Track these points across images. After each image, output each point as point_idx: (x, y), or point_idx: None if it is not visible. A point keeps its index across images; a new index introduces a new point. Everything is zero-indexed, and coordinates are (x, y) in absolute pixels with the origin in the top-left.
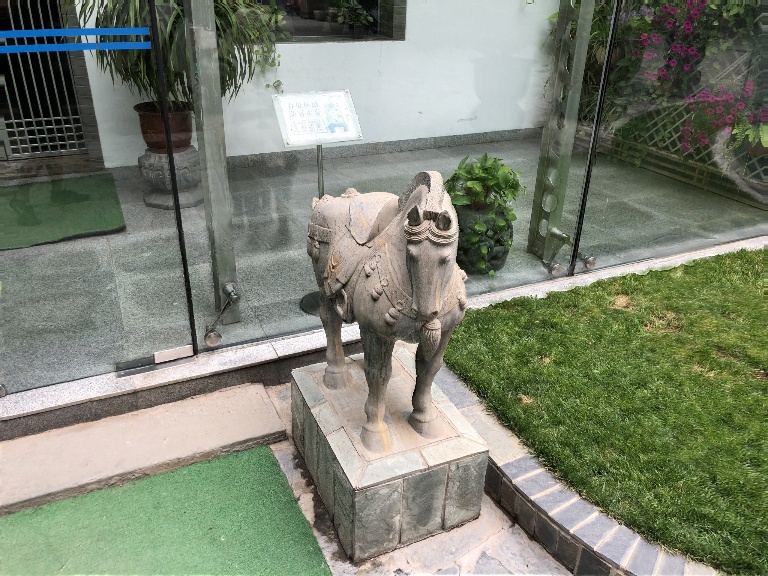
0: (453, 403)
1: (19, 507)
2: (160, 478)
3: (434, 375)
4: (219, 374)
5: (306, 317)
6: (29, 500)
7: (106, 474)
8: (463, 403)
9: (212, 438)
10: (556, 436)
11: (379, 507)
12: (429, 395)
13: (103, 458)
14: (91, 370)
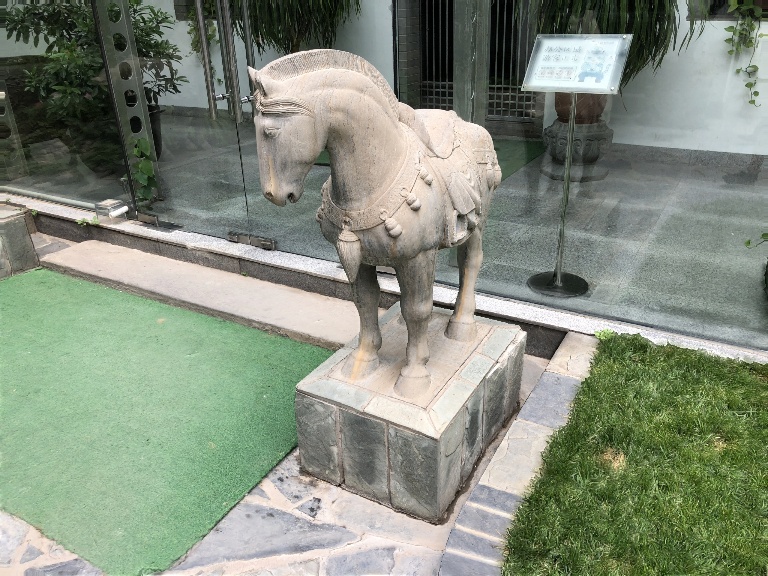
0: (531, 413)
1: (218, 314)
2: (291, 342)
3: (417, 325)
4: (397, 295)
5: (521, 287)
6: (223, 312)
7: (265, 320)
8: (541, 419)
9: (342, 335)
10: (572, 501)
11: (316, 423)
12: (416, 349)
13: (277, 311)
14: (331, 257)
